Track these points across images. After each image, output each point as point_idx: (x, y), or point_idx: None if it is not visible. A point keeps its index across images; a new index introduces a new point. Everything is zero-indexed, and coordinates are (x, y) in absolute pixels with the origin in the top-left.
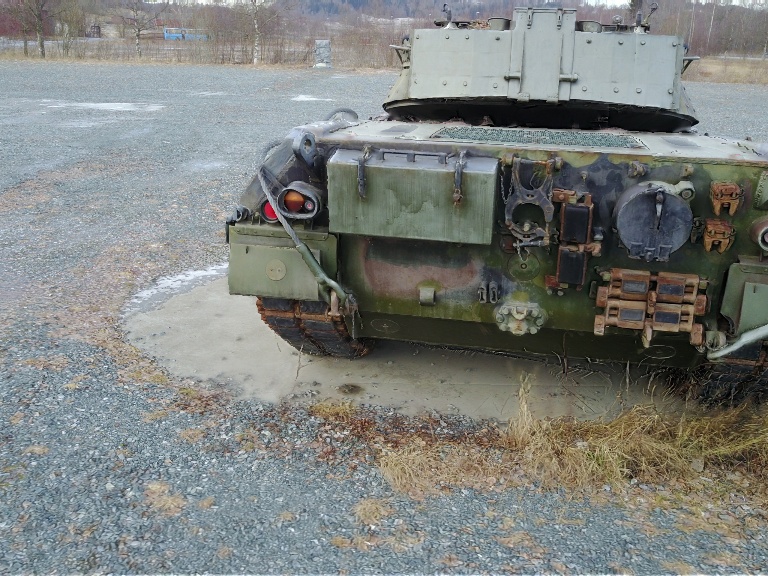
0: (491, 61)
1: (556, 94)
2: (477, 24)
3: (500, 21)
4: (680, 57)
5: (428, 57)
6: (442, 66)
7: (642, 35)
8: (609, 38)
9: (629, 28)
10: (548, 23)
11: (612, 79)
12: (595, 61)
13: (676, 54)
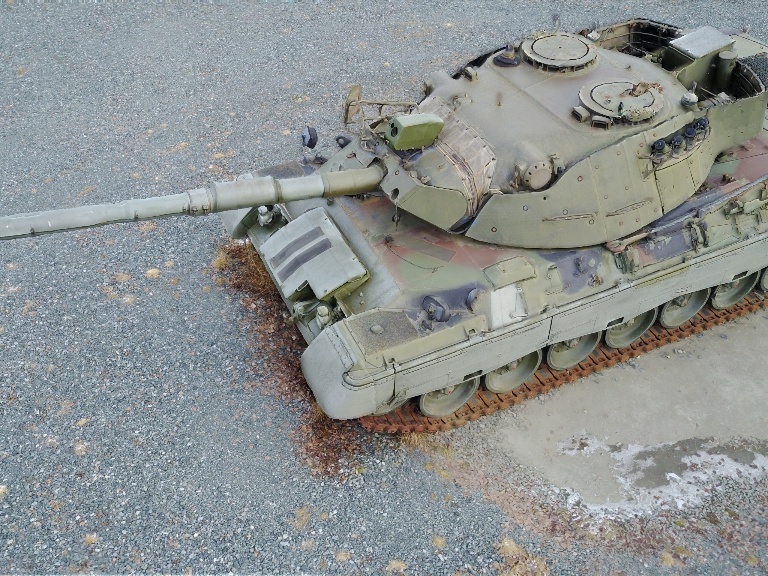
0: None
1: None
2: (656, 89)
3: None
4: None
5: None
6: None
7: None
8: None
9: None
10: None
11: None
12: None
13: None
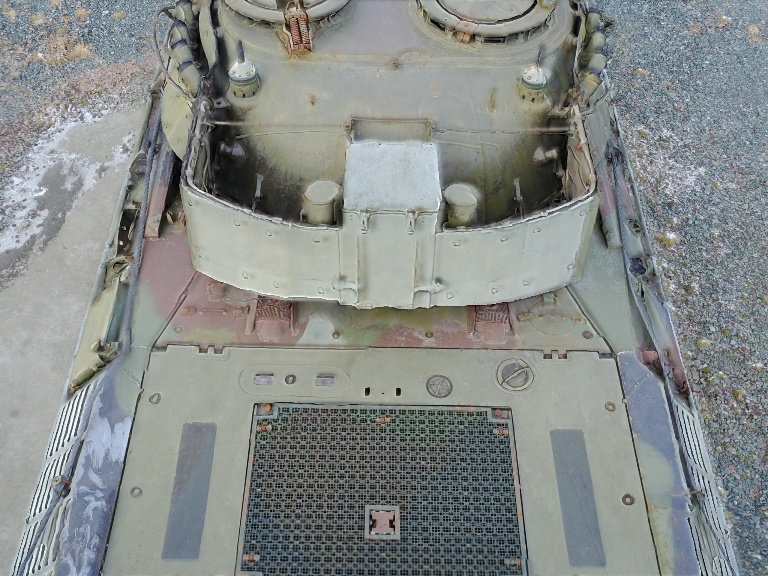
0: (310, 265)
1: (410, 305)
2: (284, 30)
3: (318, 207)
4: (589, 225)
5: (212, 236)
6: (237, 254)
7: (536, 223)
8: (487, 238)
9: (521, 37)
10: (393, 227)
11: (489, 280)
12: (465, 265)
13: (584, 222)
